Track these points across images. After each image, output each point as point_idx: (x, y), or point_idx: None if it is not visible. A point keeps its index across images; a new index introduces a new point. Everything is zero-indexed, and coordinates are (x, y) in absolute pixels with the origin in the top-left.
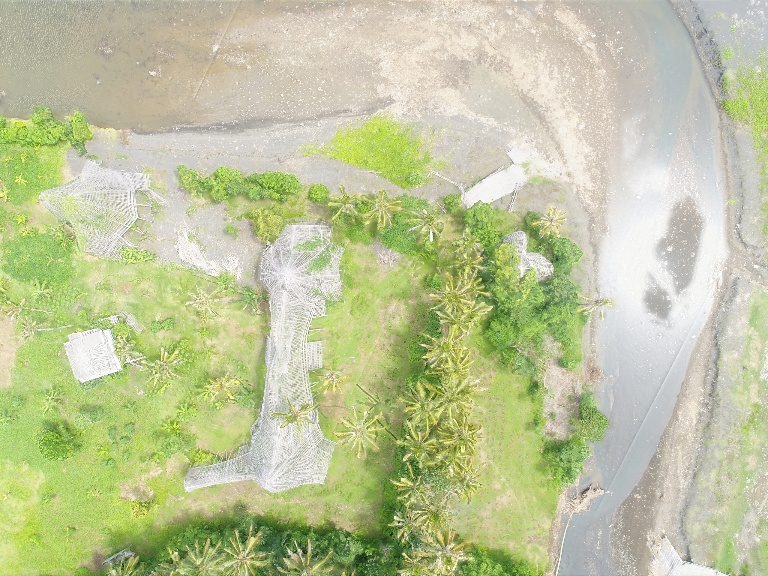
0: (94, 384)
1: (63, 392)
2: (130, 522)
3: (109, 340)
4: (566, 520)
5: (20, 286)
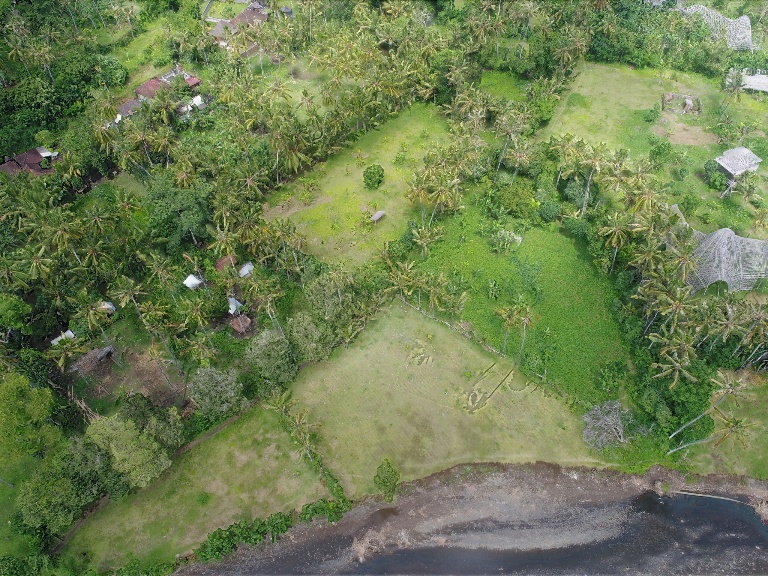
0: (713, 167)
1: (682, 164)
2: (610, 196)
3: (753, 168)
4: (742, 500)
5: (739, 145)
